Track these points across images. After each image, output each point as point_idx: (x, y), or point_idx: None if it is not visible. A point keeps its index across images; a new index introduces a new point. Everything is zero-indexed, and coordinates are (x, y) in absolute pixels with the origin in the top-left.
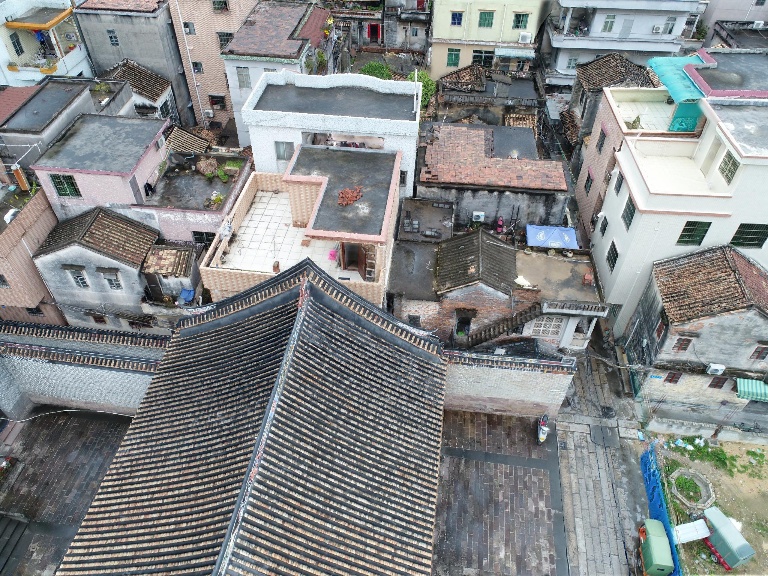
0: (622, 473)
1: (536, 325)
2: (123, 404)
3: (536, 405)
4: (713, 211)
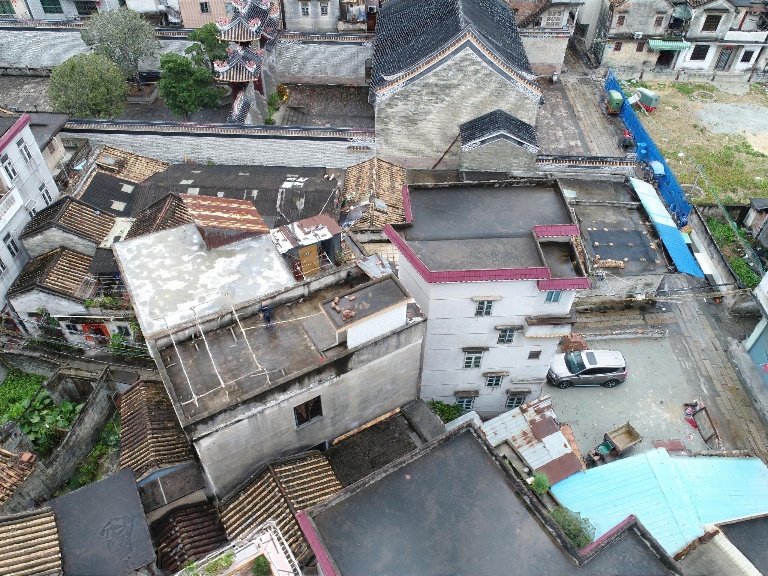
0: (596, 91)
1: (548, 19)
2: (334, 75)
3: (550, 66)
4: None
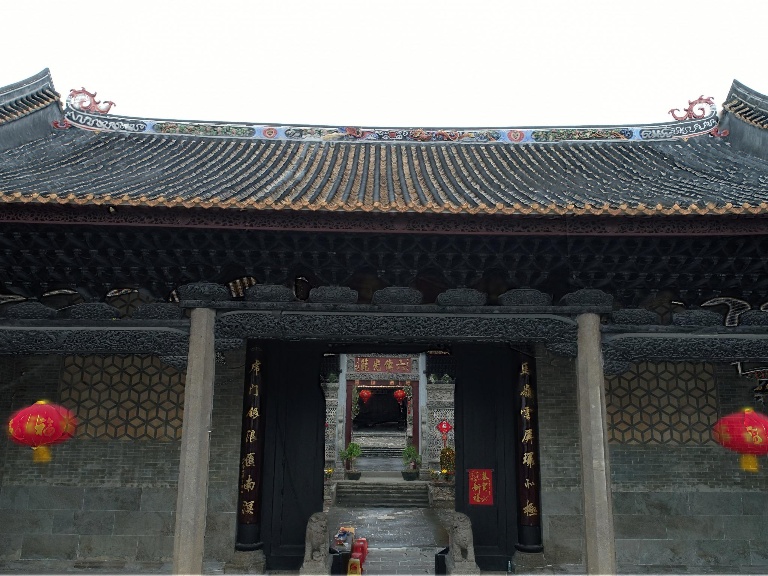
0: None
1: None
2: None
3: None
4: None
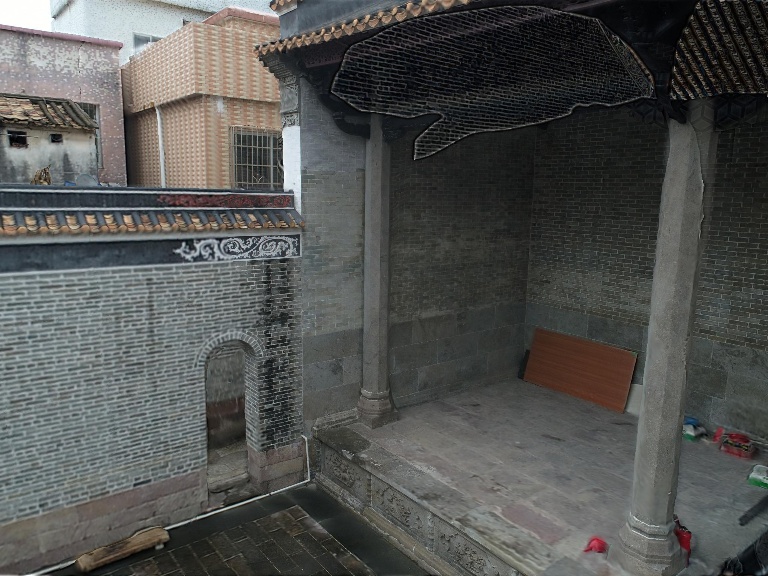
0: None
1: None
2: None
3: None
4: None
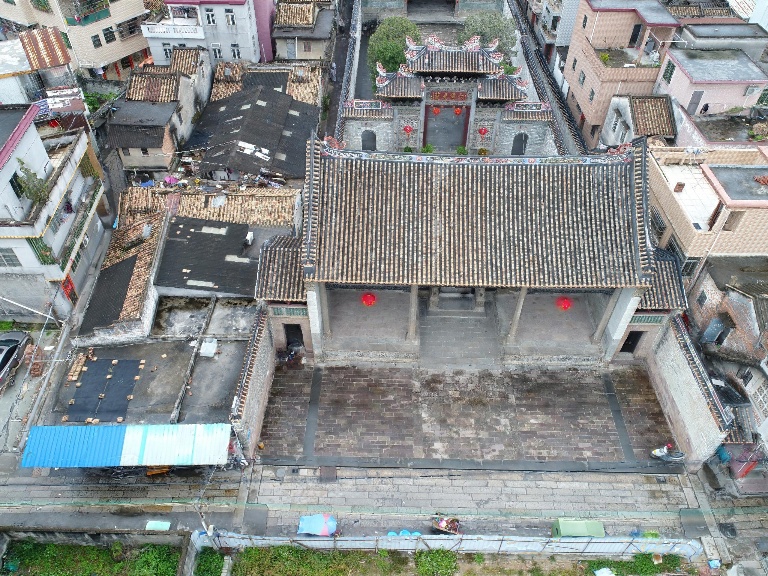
0: (656, 534)
1: (760, 389)
2: None
3: (688, 441)
4: None
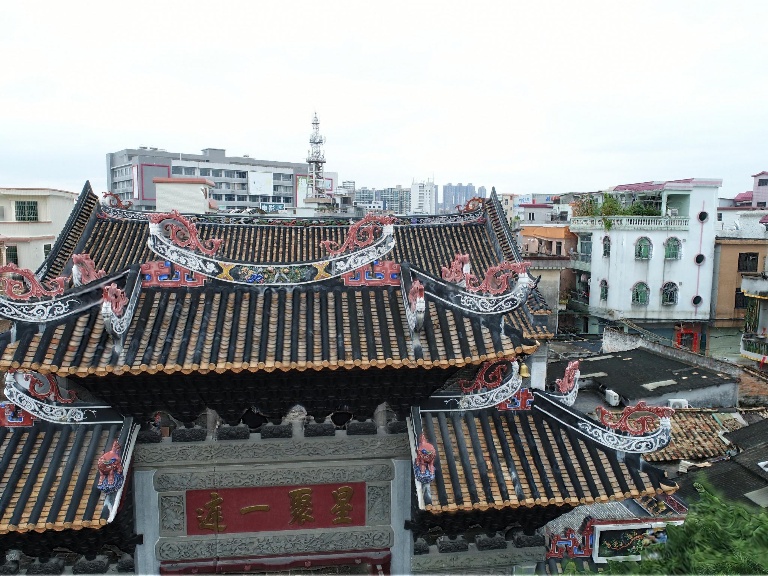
0: None
1: None
2: None
3: None
4: (49, 234)
